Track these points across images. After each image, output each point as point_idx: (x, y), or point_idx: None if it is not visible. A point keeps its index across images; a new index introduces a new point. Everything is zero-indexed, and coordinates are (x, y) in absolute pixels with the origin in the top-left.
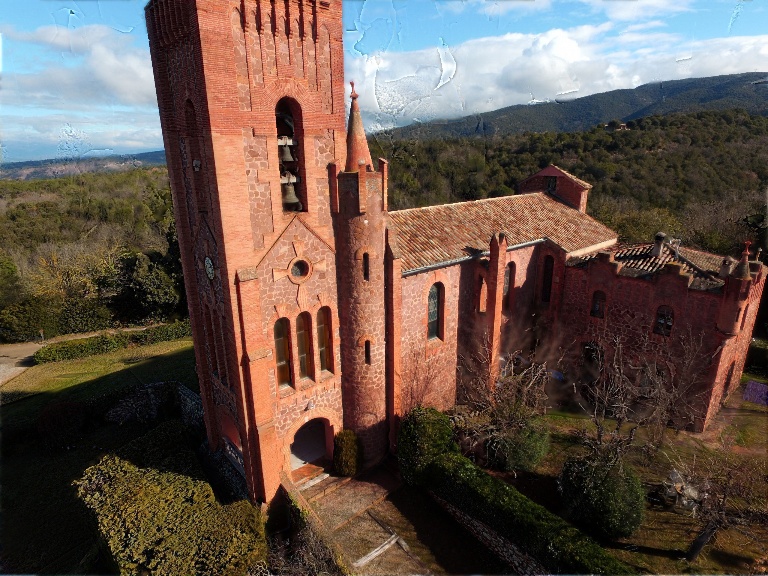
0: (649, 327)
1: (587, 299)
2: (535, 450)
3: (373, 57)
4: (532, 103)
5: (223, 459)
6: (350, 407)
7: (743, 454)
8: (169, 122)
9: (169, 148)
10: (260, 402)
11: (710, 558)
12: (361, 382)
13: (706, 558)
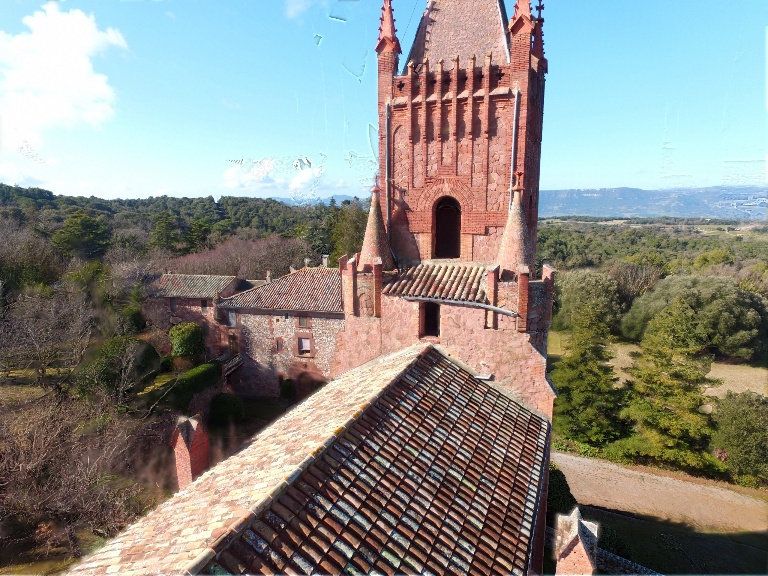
0: None
1: None
2: None
3: None
4: None
5: None
6: None
7: None
8: None
9: None
10: None
11: (60, 560)
12: None
13: (64, 559)
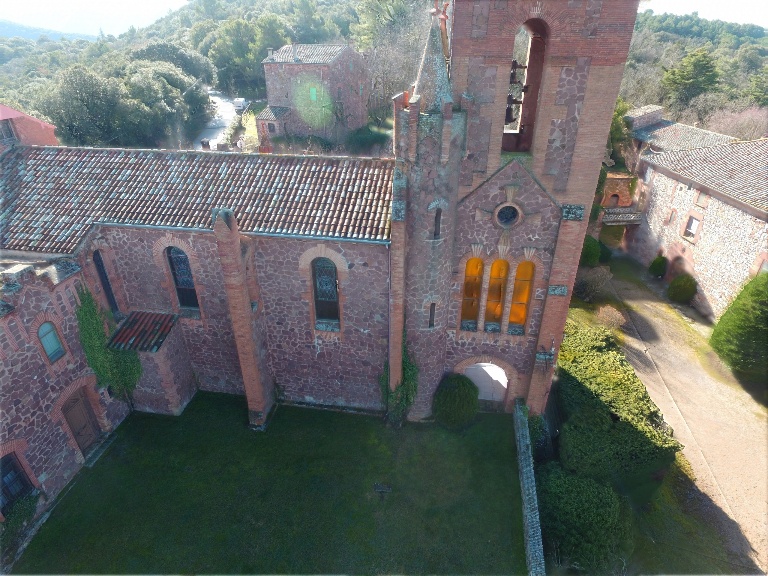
0: None
1: None
2: None
3: None
4: None
5: None
6: None
7: None
8: None
9: None
10: None
11: None
12: None
13: None
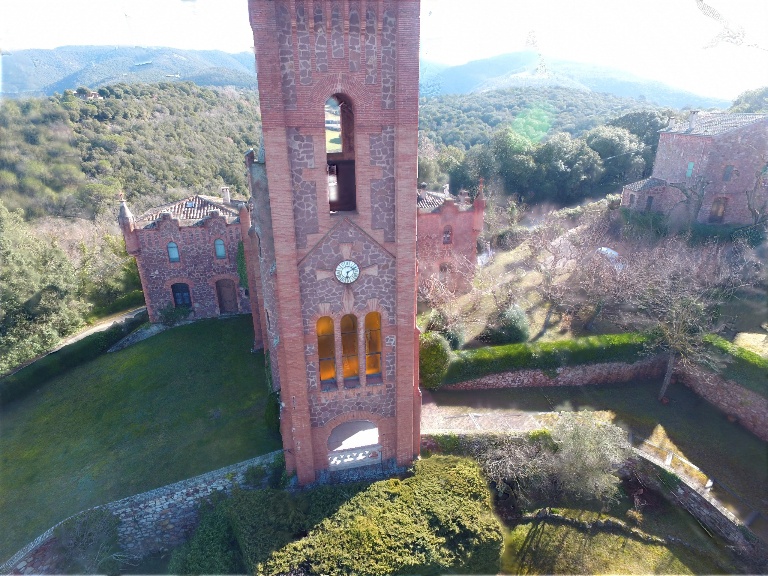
0: (441, 242)
1: None
2: None
3: None
4: (161, 77)
5: (333, 475)
6: None
7: None
8: None
9: (285, 148)
10: None
11: None
12: None
13: None
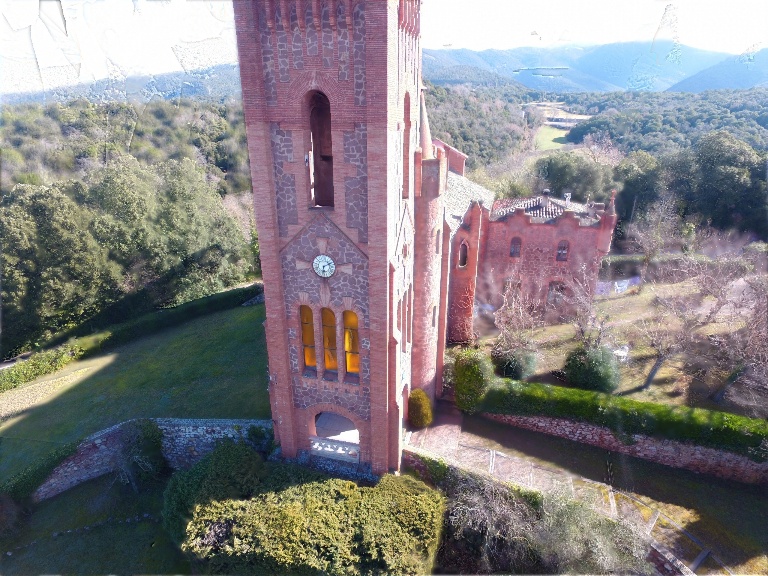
0: (553, 257)
1: (507, 245)
2: (535, 359)
3: (140, 7)
4: None
5: (312, 458)
6: (417, 369)
7: (615, 326)
8: (263, 112)
9: (263, 141)
10: (397, 380)
11: (652, 384)
12: (428, 344)
13: (651, 385)
